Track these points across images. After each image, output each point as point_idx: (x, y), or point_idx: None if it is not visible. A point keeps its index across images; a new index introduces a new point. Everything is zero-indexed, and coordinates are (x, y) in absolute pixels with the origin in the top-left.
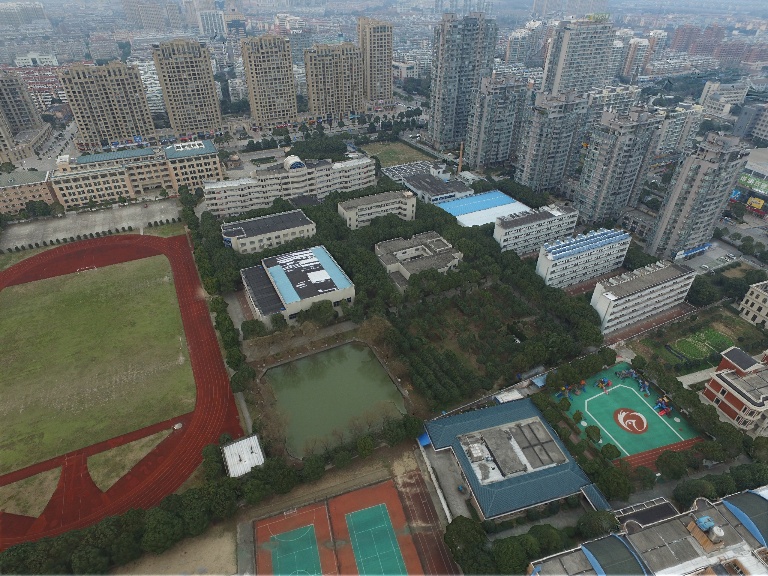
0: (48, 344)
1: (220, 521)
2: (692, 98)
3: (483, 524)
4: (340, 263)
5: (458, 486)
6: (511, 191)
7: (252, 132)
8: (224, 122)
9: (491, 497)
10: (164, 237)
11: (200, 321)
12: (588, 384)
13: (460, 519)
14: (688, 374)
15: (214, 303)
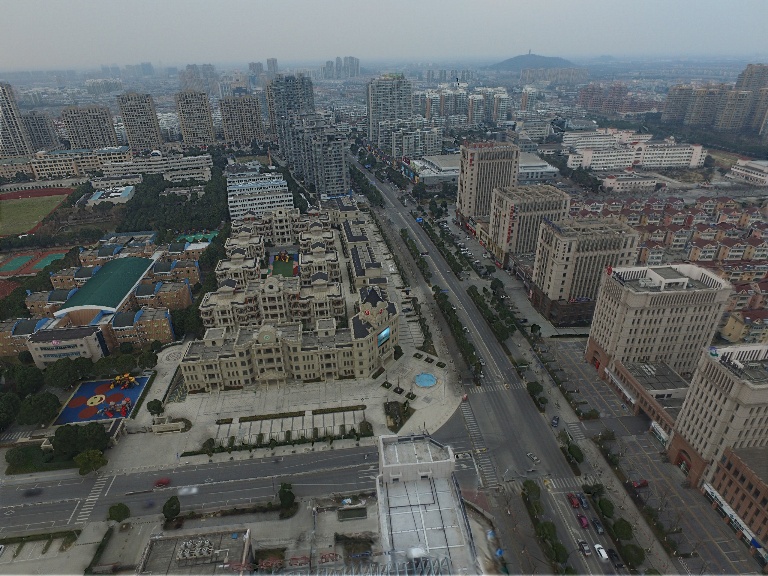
0: None
1: (4, 253)
2: None
3: None
4: None
5: None
6: None
7: None
8: None
9: None
10: None
11: None
12: (200, 233)
13: None
14: None
15: None
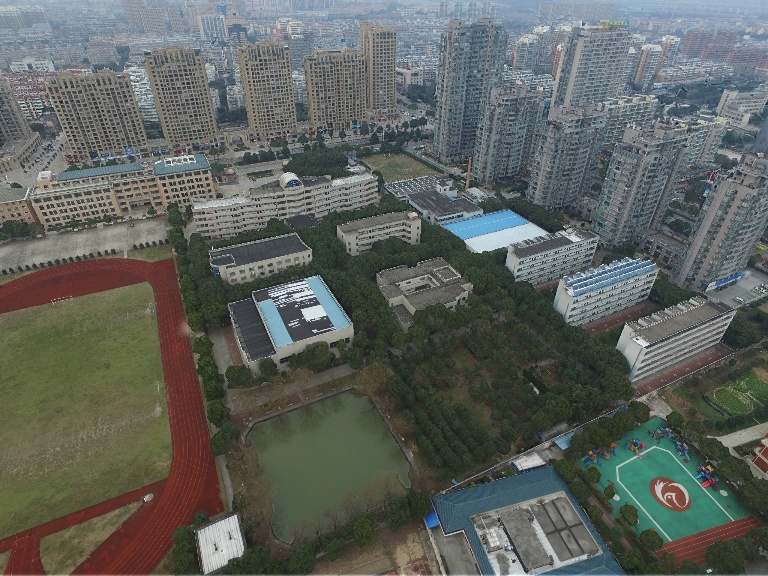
0: (11, 391)
1: None
2: (708, 107)
3: None
4: (338, 295)
5: None
6: (523, 211)
7: (249, 143)
8: (220, 132)
9: None
10: (149, 261)
11: (182, 363)
12: (618, 445)
13: None
14: (731, 433)
15: (197, 343)
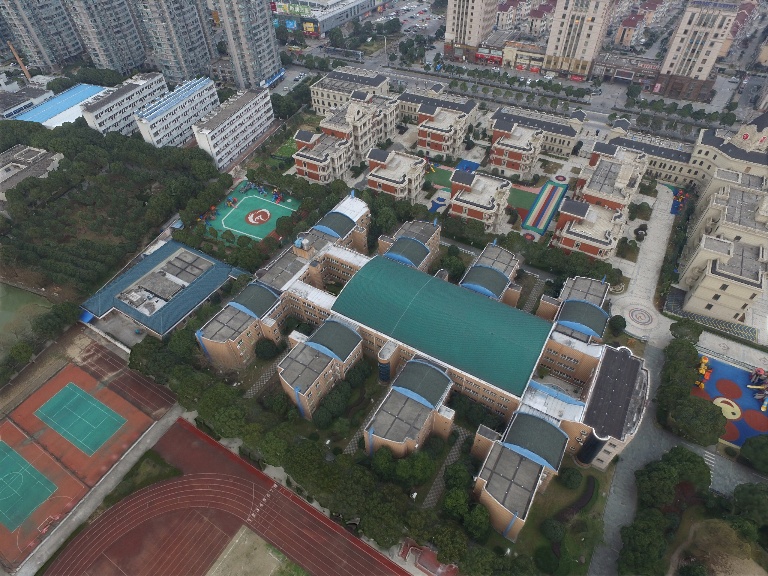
0: None
1: None
2: None
3: (162, 340)
4: None
5: (135, 332)
6: (95, 79)
7: None
8: None
9: (159, 319)
10: None
11: None
12: (220, 208)
13: (134, 345)
14: (290, 168)
15: None
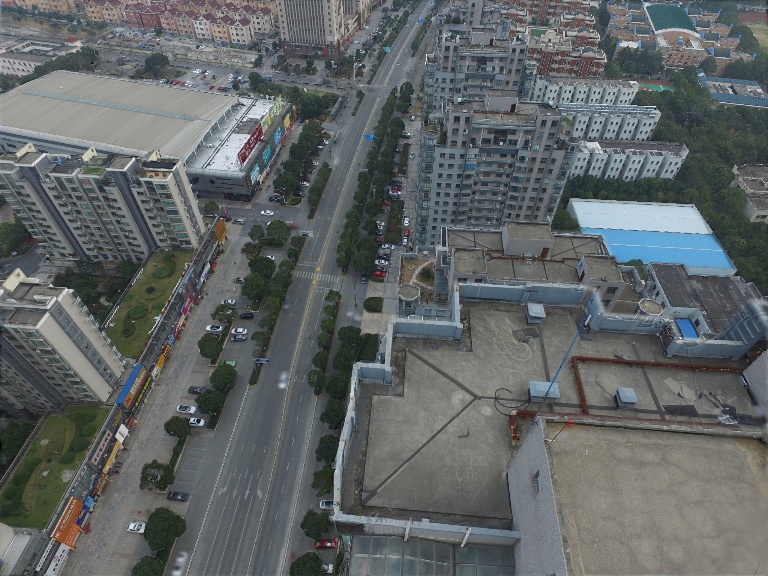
0: None
1: None
2: None
3: None
4: None
5: None
6: None
7: None
8: None
9: None
10: None
11: None
12: None
13: None
14: None
15: None
